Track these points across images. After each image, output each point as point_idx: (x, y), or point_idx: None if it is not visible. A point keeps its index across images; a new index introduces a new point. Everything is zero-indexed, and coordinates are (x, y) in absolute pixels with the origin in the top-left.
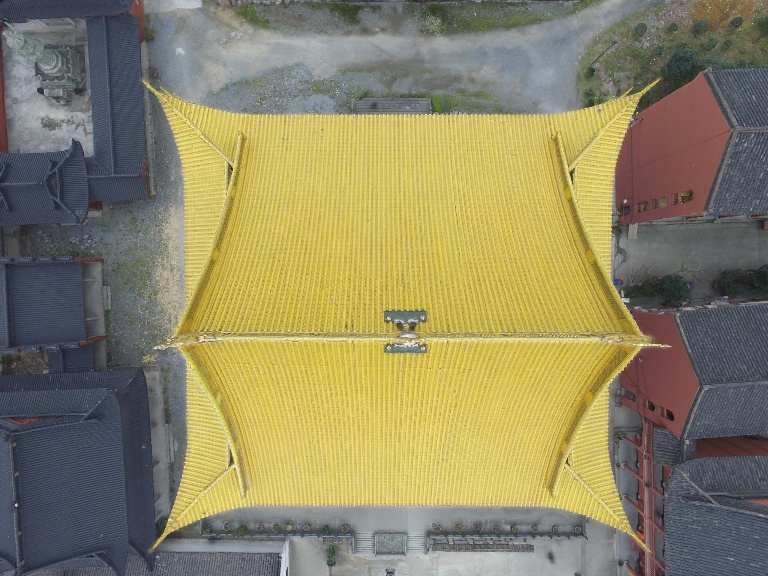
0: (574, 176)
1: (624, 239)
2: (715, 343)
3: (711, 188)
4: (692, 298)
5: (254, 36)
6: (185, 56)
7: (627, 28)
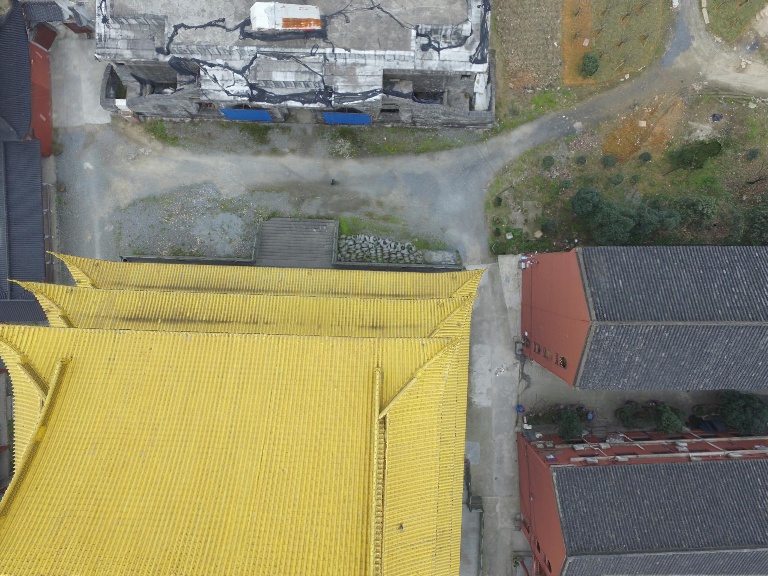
0: (386, 421)
1: (529, 365)
2: (588, 506)
3: (577, 368)
4: (594, 426)
5: (163, 153)
6: (93, 171)
7: (537, 157)
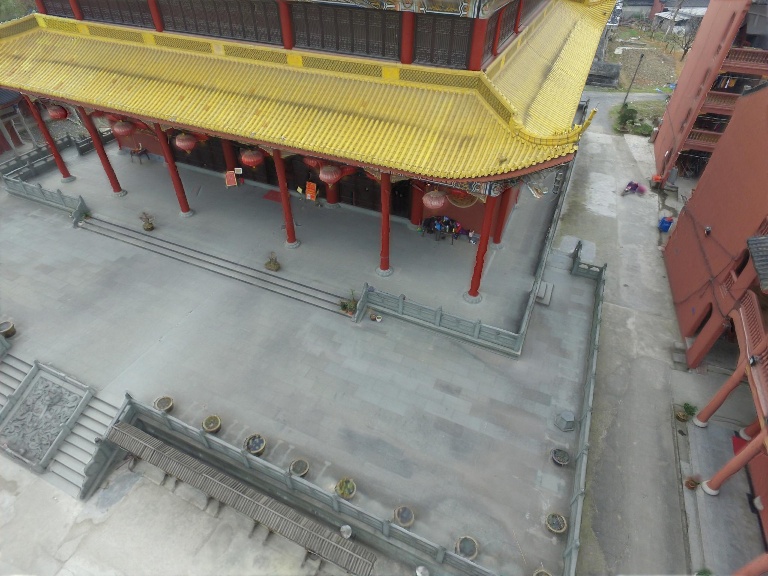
0: None
1: (672, 201)
2: None
3: None
4: None
5: None
6: None
7: (662, 104)
